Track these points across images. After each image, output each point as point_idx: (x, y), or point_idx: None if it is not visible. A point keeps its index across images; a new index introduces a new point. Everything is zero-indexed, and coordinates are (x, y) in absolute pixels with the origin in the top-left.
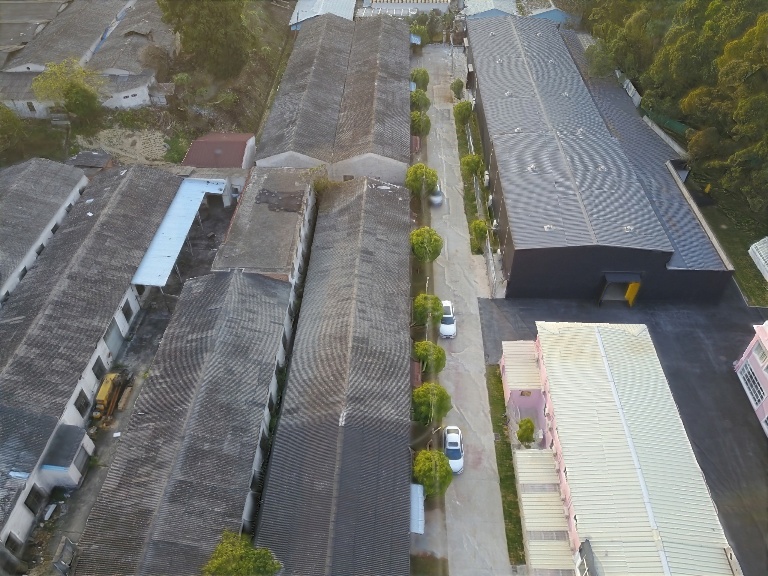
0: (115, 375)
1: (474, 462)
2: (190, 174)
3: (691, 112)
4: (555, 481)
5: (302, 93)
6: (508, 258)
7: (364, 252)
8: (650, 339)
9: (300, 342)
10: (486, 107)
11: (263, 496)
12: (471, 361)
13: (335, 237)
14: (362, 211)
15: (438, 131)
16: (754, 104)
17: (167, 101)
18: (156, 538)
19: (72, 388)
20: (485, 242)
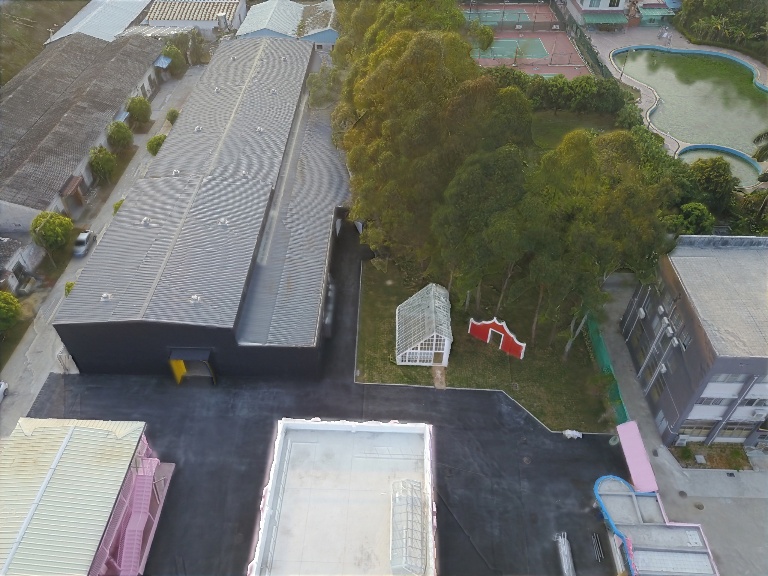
0: None
1: None
2: None
3: None
4: None
5: None
6: None
7: None
8: (135, 442)
9: None
10: (164, 144)
11: None
12: None
13: None
14: None
15: (140, 167)
16: (354, 154)
17: None
18: None
19: None
20: None
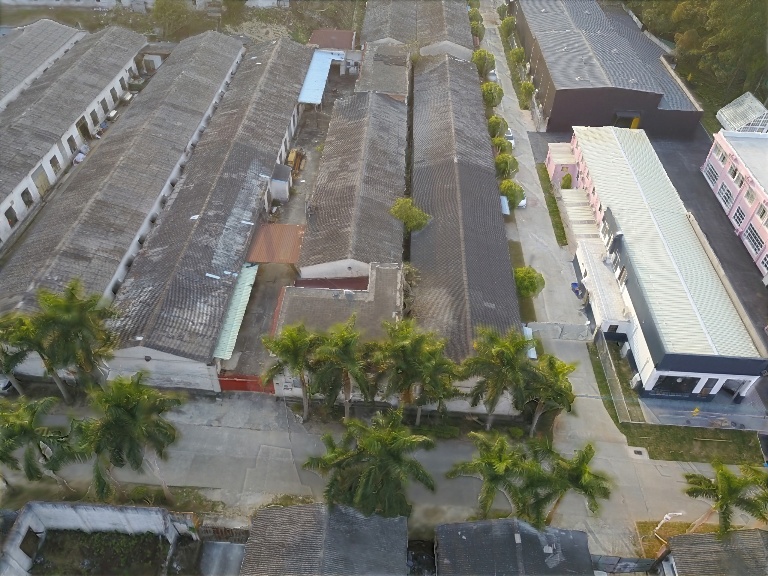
0: (297, 149)
1: (532, 204)
2: (319, 47)
3: (679, 19)
4: (586, 201)
5: (388, 5)
6: (549, 105)
7: (453, 90)
8: (646, 135)
9: (418, 134)
10: (528, 18)
11: (411, 195)
12: (526, 161)
13: (430, 85)
14: (447, 70)
15: (488, 41)
16: (721, 2)
17: (290, 4)
18: (361, 195)
19: (280, 144)
20: (531, 98)
